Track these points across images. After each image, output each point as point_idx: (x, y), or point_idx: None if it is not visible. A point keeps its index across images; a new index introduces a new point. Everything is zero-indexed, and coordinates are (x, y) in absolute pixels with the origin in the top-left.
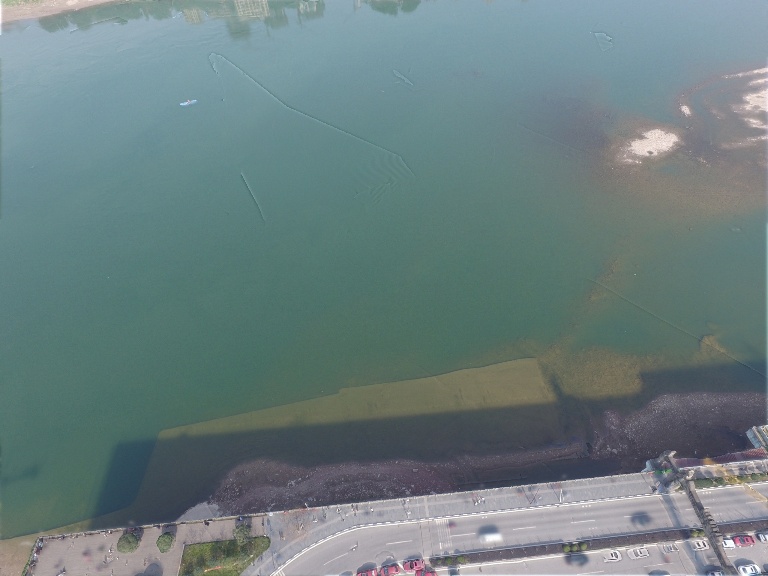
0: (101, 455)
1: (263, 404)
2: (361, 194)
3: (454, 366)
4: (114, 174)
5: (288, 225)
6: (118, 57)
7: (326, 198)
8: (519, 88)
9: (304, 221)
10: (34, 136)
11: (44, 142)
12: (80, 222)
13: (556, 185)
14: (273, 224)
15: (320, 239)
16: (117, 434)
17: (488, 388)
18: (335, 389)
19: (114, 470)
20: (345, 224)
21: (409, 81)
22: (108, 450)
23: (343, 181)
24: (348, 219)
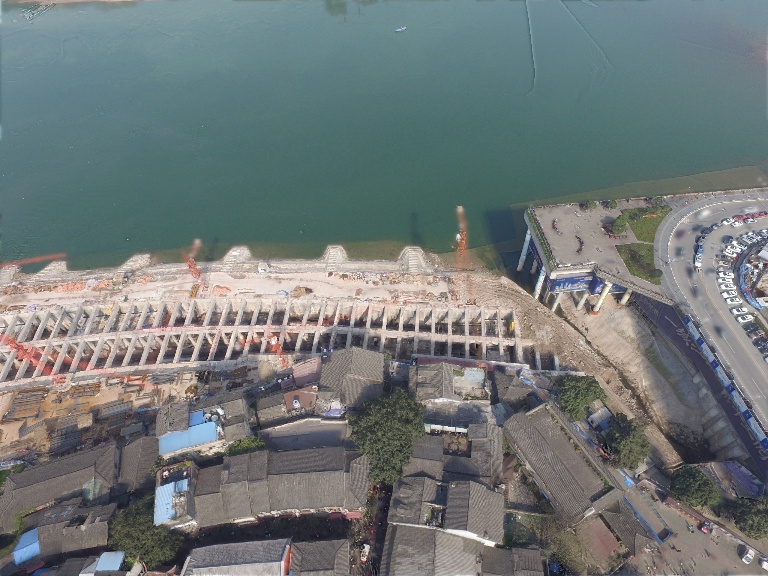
0: (478, 216)
1: (573, 192)
2: (593, 72)
3: (698, 171)
4: (373, 74)
5: (546, 92)
6: (319, 2)
7: (573, 72)
8: (668, 15)
9: (557, 89)
10: (289, 53)
11: (300, 57)
12: (369, 101)
13: (725, 75)
14: (538, 89)
15: (566, 104)
16: (482, 206)
17: (730, 180)
18: (620, 184)
19: (493, 222)
20: (579, 96)
21: (593, 4)
22: (481, 213)
23: (584, 60)
24: (581, 92)
